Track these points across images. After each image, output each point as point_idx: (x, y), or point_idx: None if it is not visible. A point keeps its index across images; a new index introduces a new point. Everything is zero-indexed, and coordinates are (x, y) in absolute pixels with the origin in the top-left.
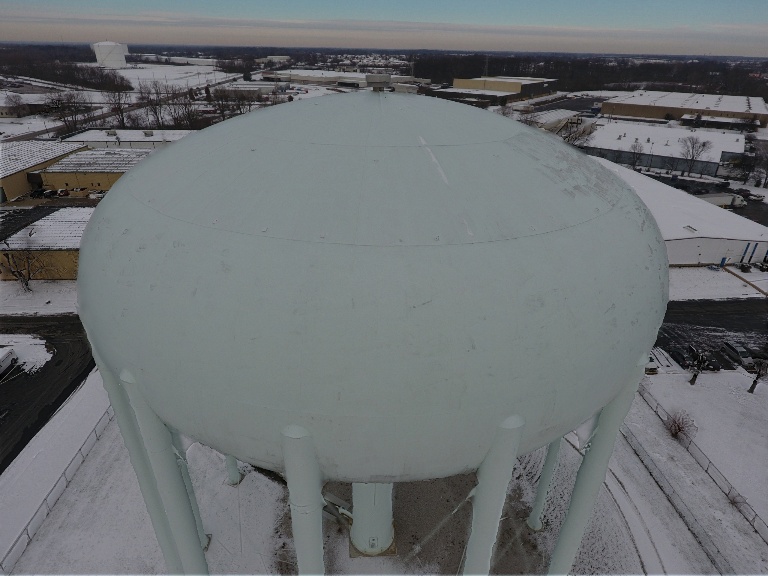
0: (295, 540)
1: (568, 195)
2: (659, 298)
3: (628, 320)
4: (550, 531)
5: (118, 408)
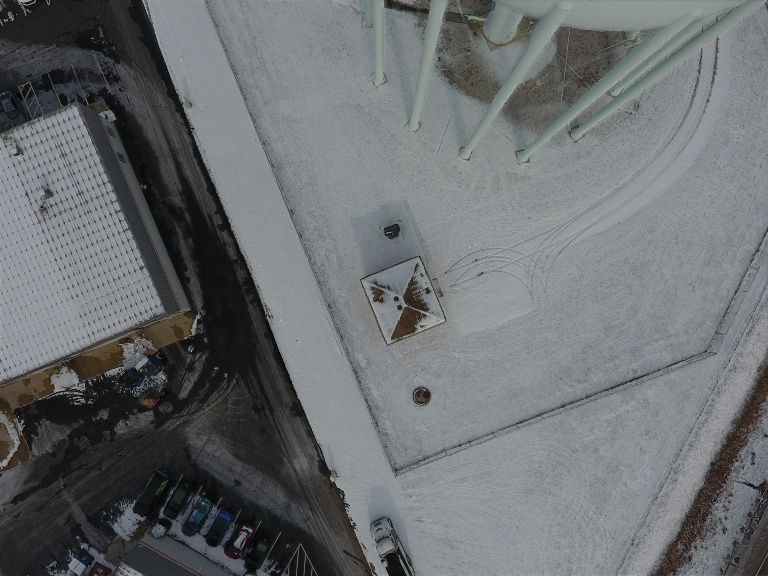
0: (630, 64)
1: None
2: None
3: None
4: None
5: (440, 15)
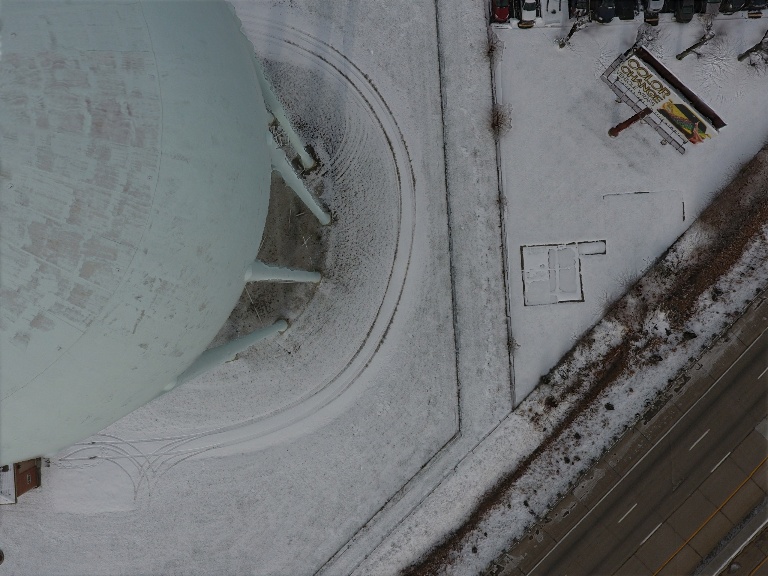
0: None
1: (18, 345)
2: (171, 360)
3: (116, 408)
4: (335, 225)
5: None
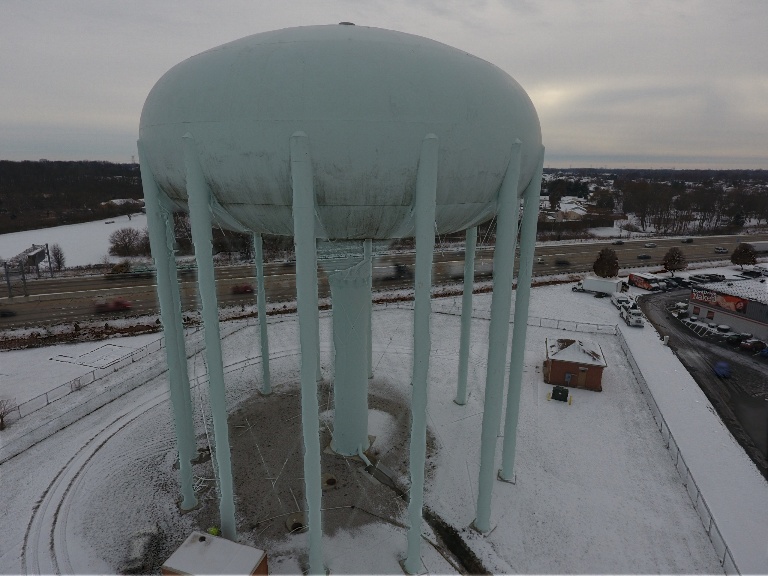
0: None
1: None
2: None
3: None
4: None
5: None
